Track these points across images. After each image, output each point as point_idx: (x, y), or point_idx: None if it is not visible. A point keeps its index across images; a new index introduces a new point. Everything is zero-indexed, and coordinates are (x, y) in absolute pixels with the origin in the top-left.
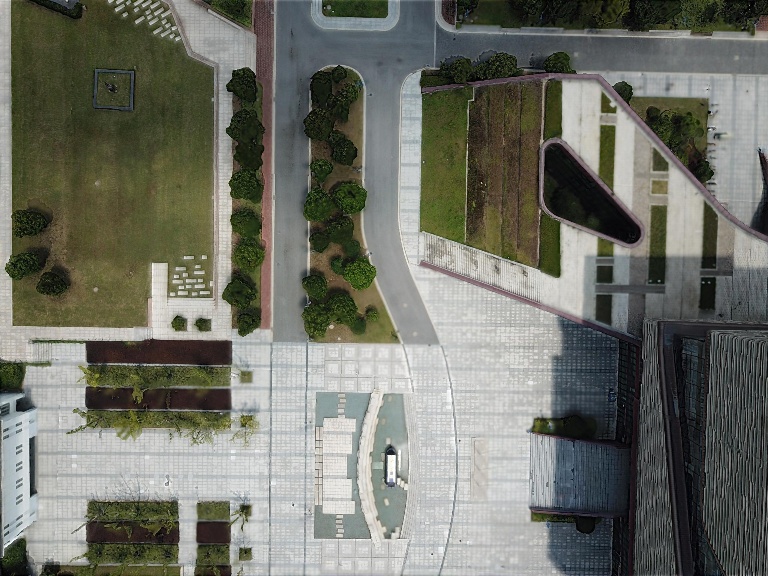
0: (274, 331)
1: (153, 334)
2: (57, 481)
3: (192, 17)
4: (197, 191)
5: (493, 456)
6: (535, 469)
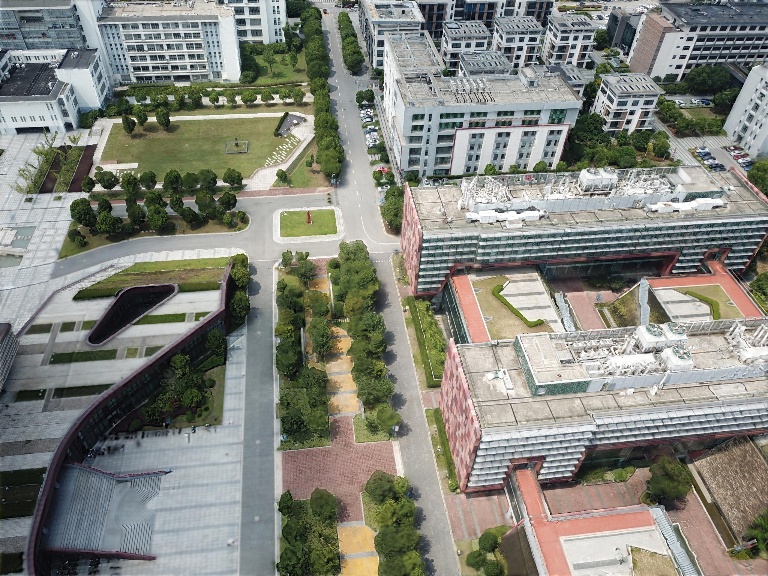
0: None
1: (96, 165)
2: (22, 140)
3: None
4: None
5: None
6: None
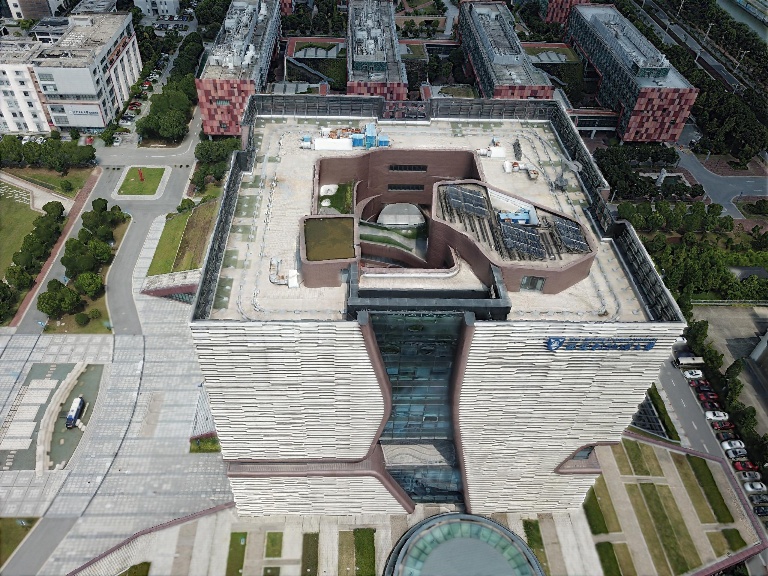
0: (18, 328)
1: None
2: None
3: (41, 197)
4: (3, 261)
5: (166, 404)
6: (200, 411)
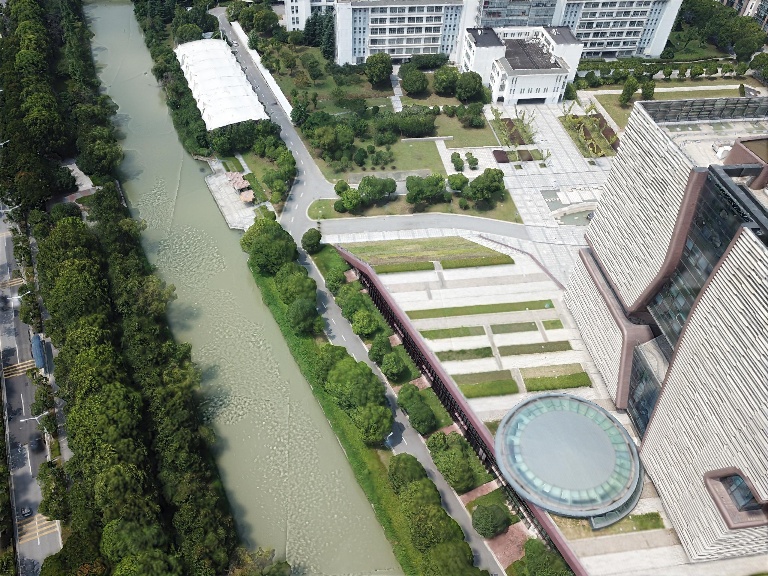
0: None
1: None
2: (525, 110)
3: None
4: None
5: None
6: None
